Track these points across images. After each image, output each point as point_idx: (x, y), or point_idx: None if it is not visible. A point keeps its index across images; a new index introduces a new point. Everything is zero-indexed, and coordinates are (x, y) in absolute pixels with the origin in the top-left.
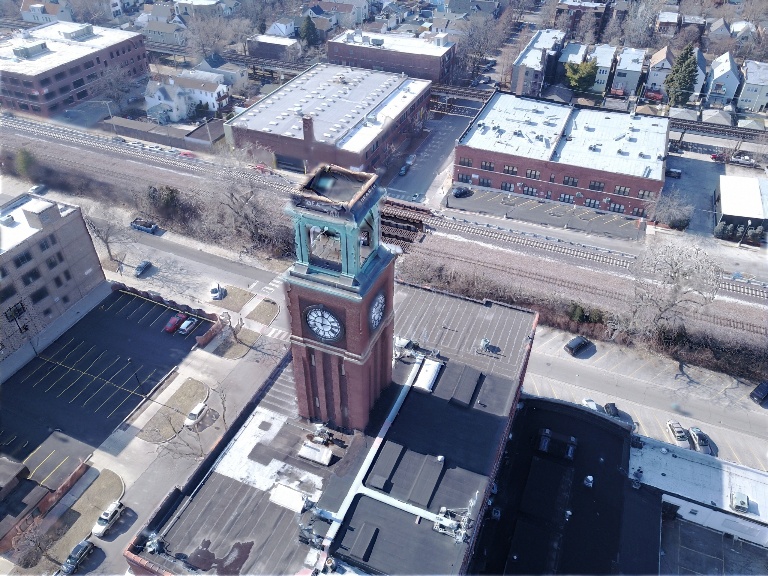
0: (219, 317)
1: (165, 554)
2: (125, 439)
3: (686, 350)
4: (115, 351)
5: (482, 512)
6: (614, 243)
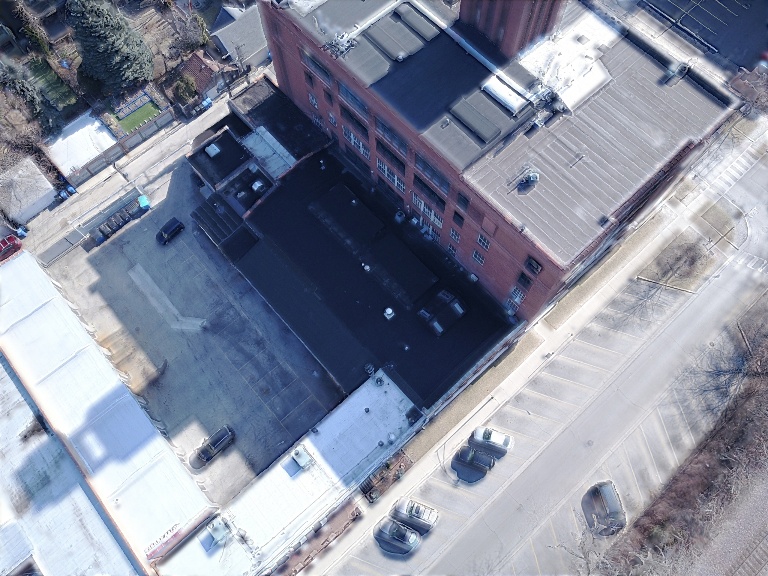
0: None
1: None
2: (627, 4)
3: None
4: (759, 5)
5: (383, 157)
6: None
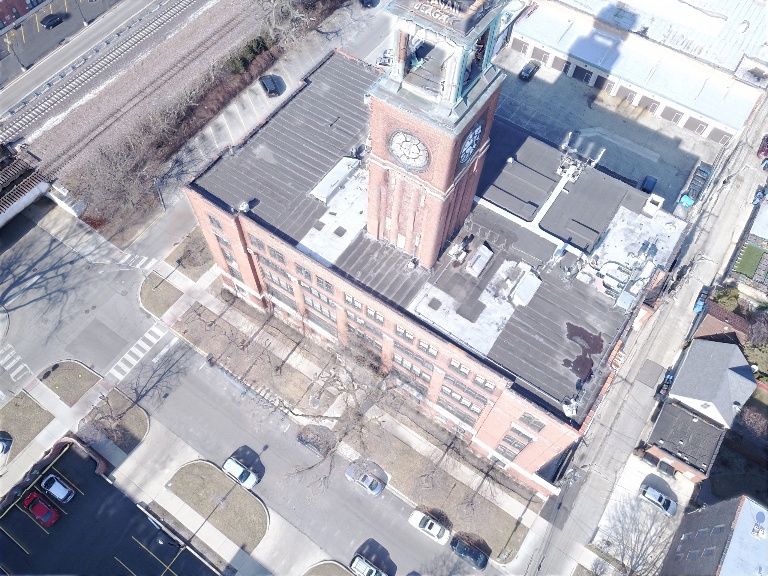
0: (66, 438)
1: (577, 399)
2: (251, 569)
3: (309, 17)
4: None
5: None
6: (136, 0)
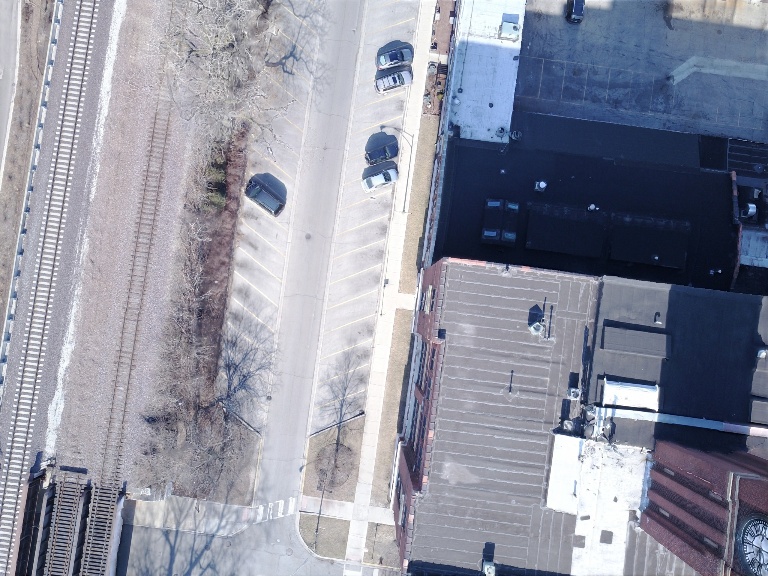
0: None
1: None
2: None
3: None
4: None
5: None
6: None
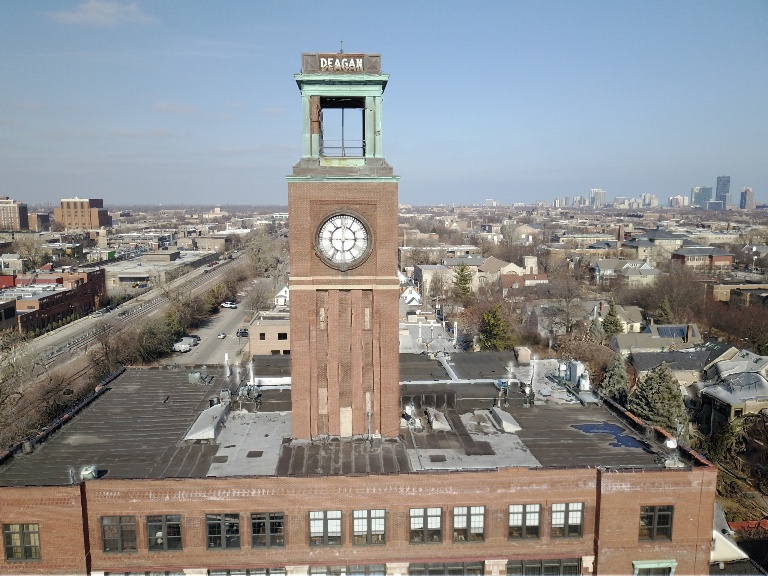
0: None
1: (666, 458)
2: None
3: None
4: None
5: None
6: None
